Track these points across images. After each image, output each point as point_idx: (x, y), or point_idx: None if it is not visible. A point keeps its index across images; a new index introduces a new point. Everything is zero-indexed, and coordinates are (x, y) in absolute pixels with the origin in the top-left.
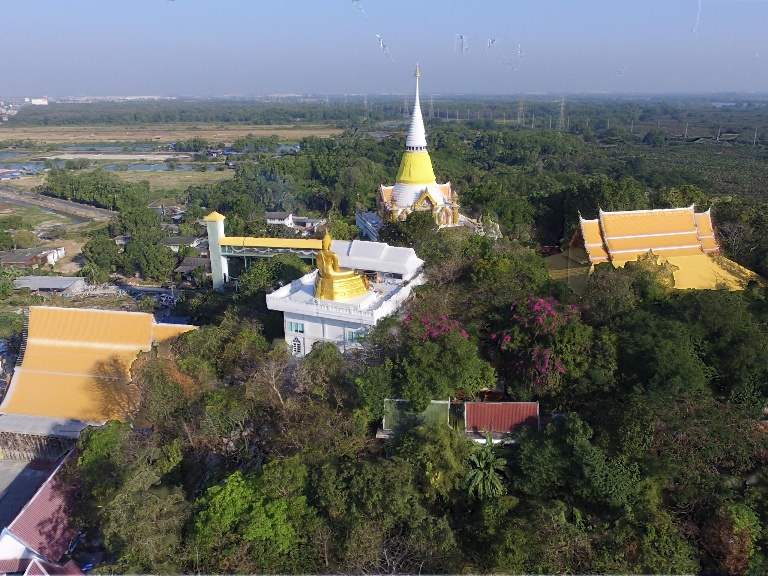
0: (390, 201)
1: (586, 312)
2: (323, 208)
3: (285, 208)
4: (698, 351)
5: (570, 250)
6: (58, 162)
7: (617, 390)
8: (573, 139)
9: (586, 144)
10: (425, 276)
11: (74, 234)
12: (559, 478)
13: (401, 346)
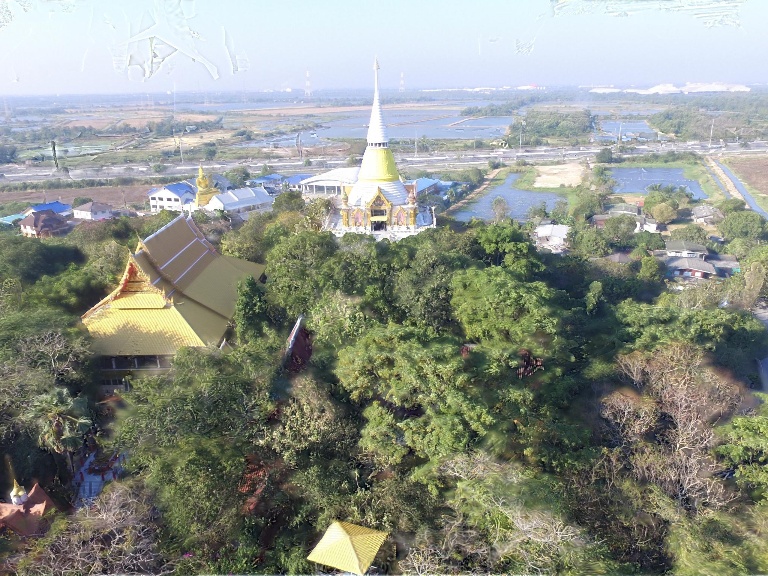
0: None
1: None
2: None
3: None
4: None
5: None
6: None
7: None
8: None
9: None
10: None
11: None
12: None
13: None
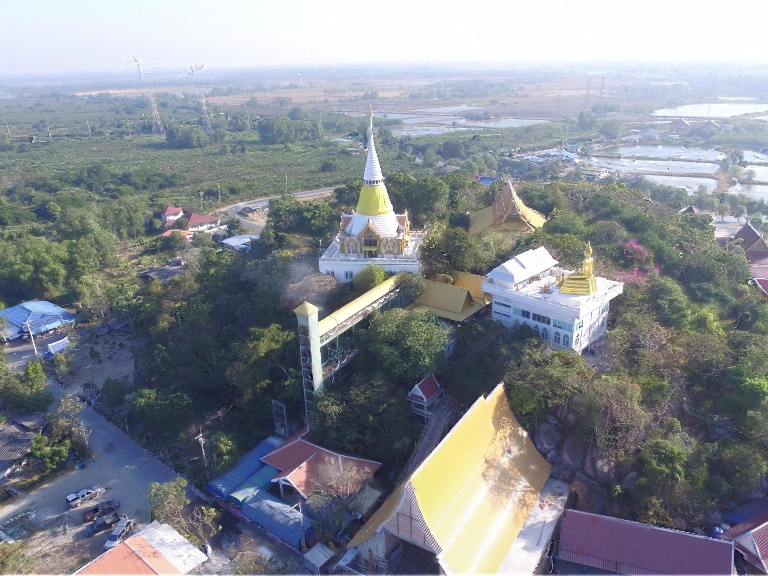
0: (381, 233)
1: None
2: None
3: None
4: None
5: (503, 225)
6: None
7: None
8: None
9: None
10: None
11: None
12: (720, 310)
13: (648, 293)
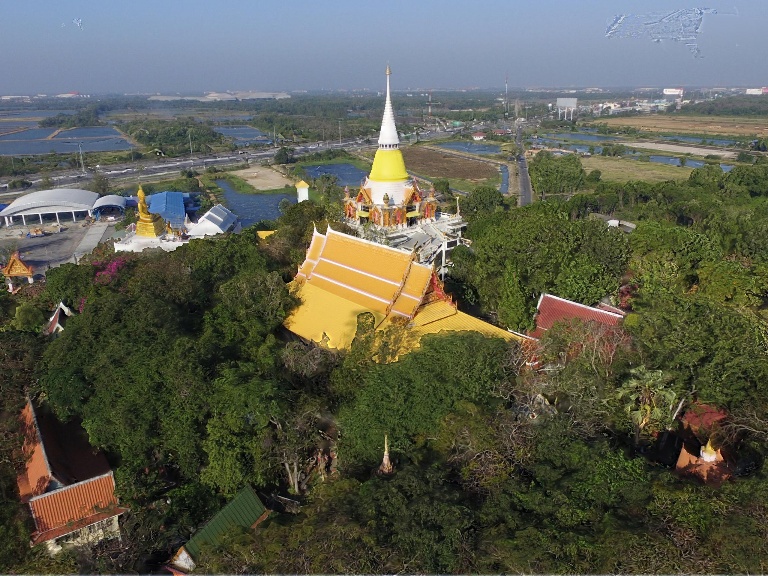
0: None
1: None
2: None
3: (645, 216)
4: None
5: None
6: (600, 148)
7: None
8: None
9: None
10: None
11: None
12: None
13: None
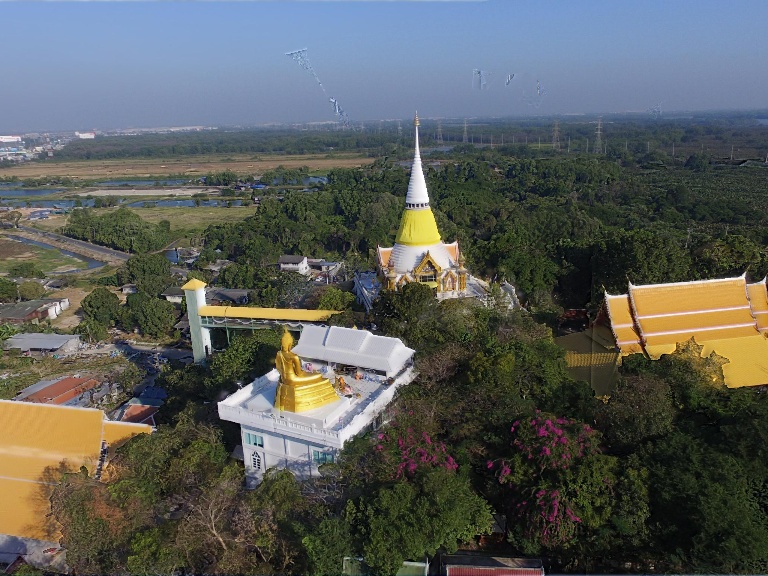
0: None
1: (610, 428)
2: (342, 248)
3: (302, 250)
4: (759, 497)
5: (594, 329)
6: (88, 200)
7: (650, 545)
8: (610, 166)
9: (624, 170)
10: (415, 370)
11: (84, 281)
12: None
13: (369, 483)
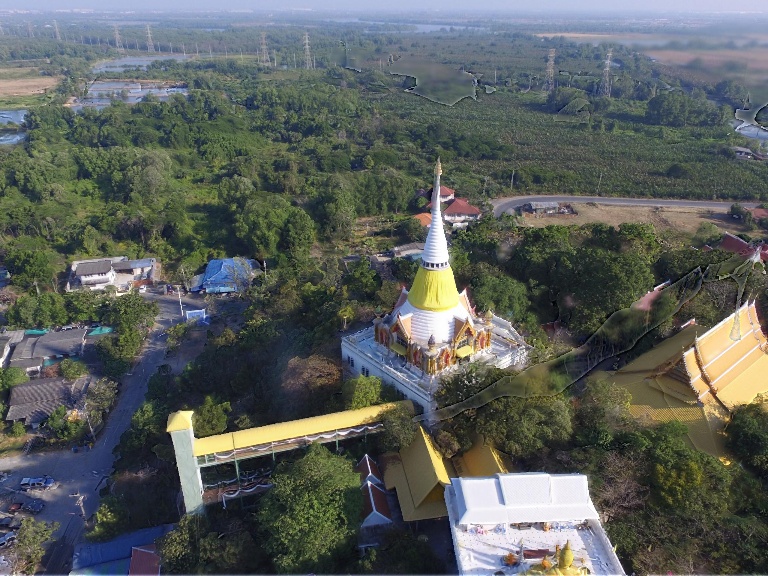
0: (414, 336)
1: None
2: (135, 235)
3: (87, 246)
4: None
5: (659, 380)
6: None
7: None
8: (350, 94)
9: None
10: None
11: None
12: None
13: None
